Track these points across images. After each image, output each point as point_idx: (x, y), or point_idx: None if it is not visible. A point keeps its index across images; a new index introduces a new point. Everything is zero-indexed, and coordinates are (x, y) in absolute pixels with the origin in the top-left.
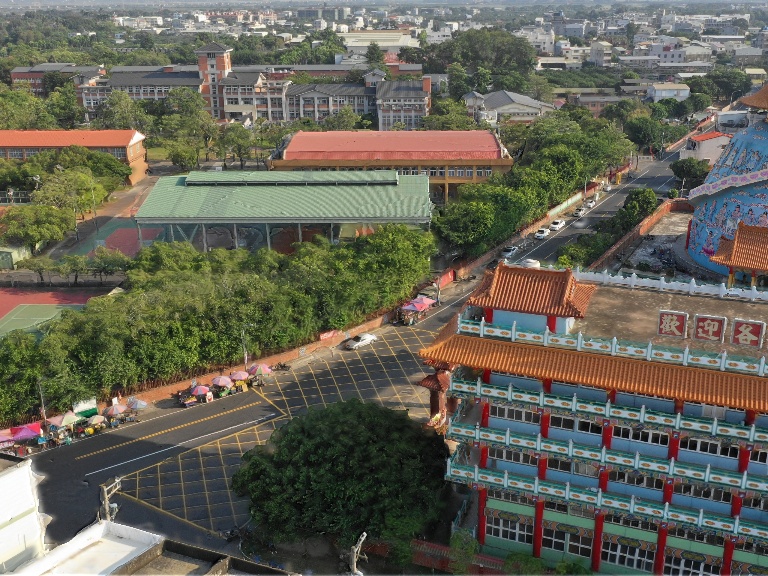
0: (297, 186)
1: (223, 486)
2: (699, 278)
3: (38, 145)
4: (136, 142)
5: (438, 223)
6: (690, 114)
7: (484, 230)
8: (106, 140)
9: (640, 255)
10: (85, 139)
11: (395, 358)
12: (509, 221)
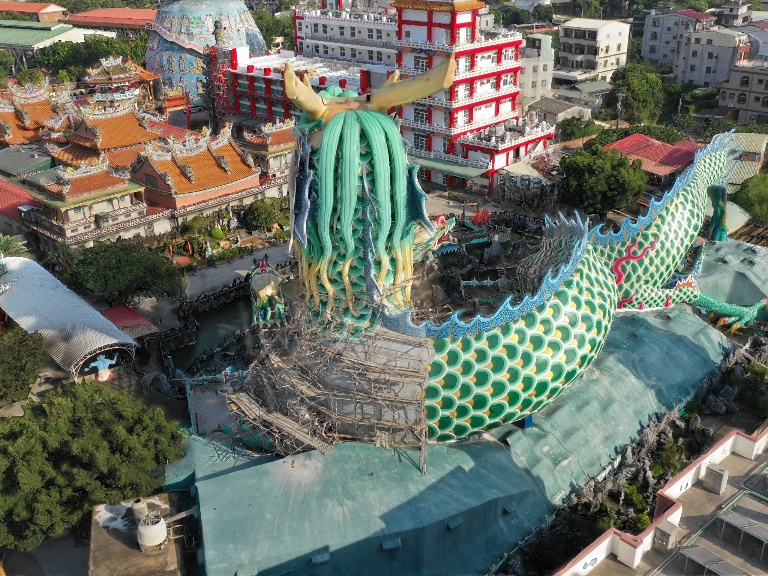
0: (10, 28)
1: None
2: None
3: (1, 10)
4: (53, 11)
5: (38, 50)
6: (535, 23)
7: (59, 56)
8: (32, 8)
9: None
10: (23, 7)
11: None
12: (95, 56)
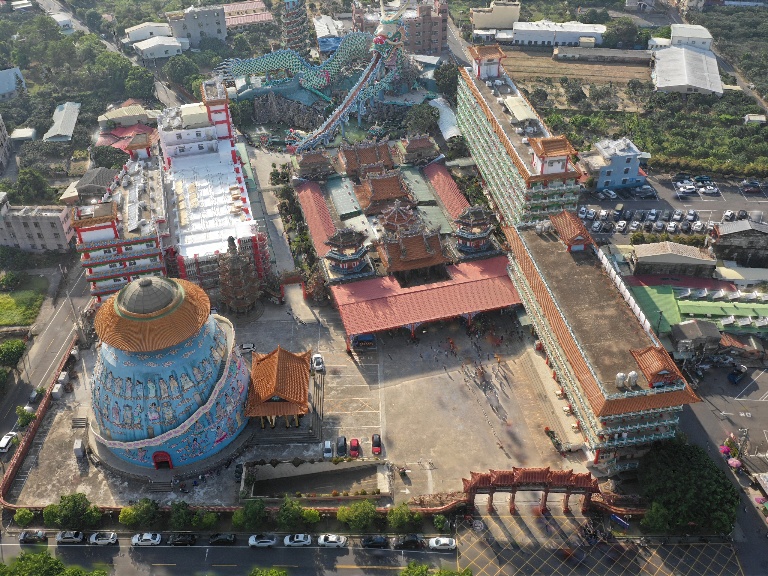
0: None
1: (709, 572)
2: (244, 451)
3: None
4: None
5: None
6: None
7: None
8: None
9: (192, 500)
10: None
11: (517, 574)
12: None
